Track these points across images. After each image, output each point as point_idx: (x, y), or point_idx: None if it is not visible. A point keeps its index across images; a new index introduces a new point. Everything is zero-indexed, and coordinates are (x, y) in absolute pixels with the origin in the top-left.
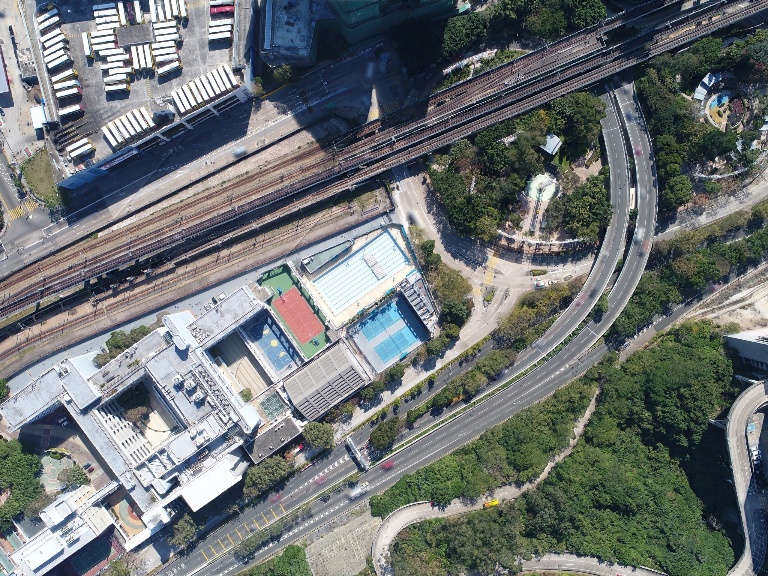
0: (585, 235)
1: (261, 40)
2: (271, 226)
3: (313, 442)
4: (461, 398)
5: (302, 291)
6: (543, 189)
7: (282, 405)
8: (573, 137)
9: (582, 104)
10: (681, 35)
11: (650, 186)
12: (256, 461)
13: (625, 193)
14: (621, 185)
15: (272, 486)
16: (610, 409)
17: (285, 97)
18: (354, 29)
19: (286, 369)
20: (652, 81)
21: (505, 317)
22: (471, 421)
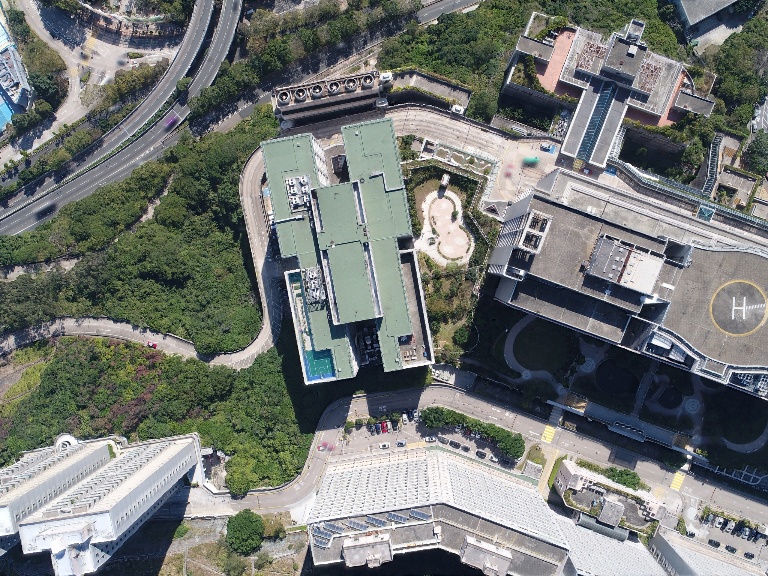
0: (166, 11)
1: None
2: None
3: None
4: (53, 178)
5: None
6: None
7: None
8: None
9: None
10: None
11: None
12: None
13: None
14: None
15: None
16: (177, 187)
17: None
18: None
19: None
20: None
21: (101, 99)
22: (58, 200)
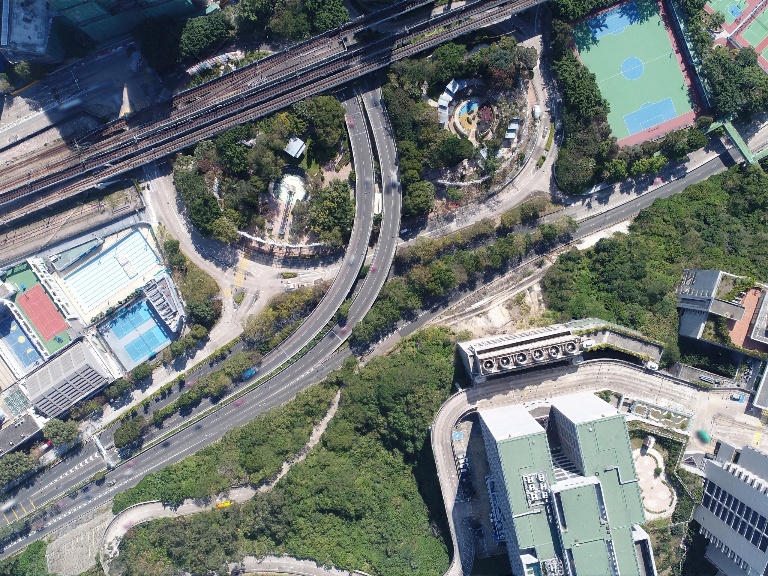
0: (326, 239)
1: None
2: (22, 222)
3: (52, 439)
4: (209, 399)
5: None
6: (293, 192)
7: (26, 401)
8: None
9: (322, 108)
10: (422, 41)
11: (395, 191)
12: None
13: (370, 198)
14: (367, 190)
15: (22, 481)
16: (345, 413)
17: (37, 94)
18: (87, 27)
19: (33, 365)
20: (393, 86)
21: None
22: (217, 422)
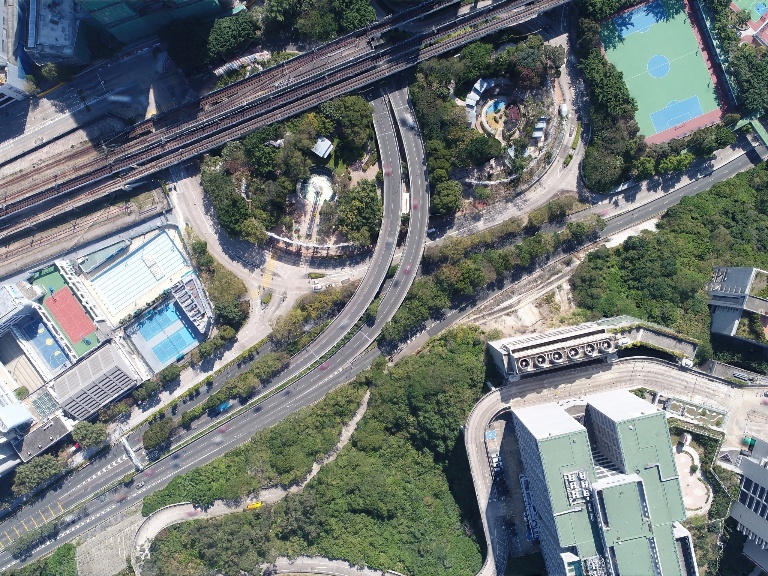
0: (354, 239)
1: (25, 38)
2: (48, 225)
3: (81, 441)
4: (237, 400)
5: (74, 290)
6: (320, 192)
7: (54, 404)
8: (348, 141)
9: (350, 108)
10: (450, 40)
11: (423, 191)
12: (25, 459)
13: (398, 198)
14: (394, 189)
15: (50, 484)
16: (375, 413)
17: (63, 95)
18: (115, 29)
19: (61, 368)
20: (421, 86)
21: None
22: (246, 423)
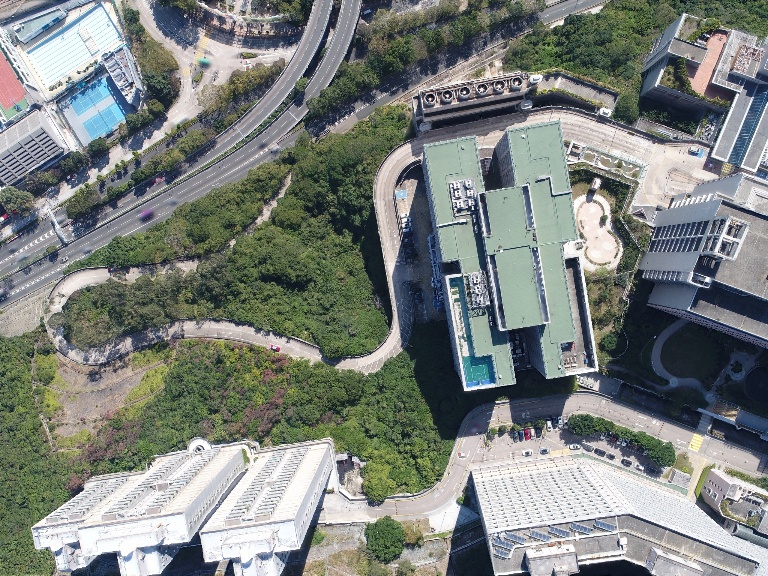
0: (285, 11)
1: None
2: None
3: (6, 205)
4: (164, 179)
5: (7, 55)
6: None
7: None
8: None
9: None
10: None
11: None
12: None
13: None
14: None
15: None
16: (295, 189)
17: None
18: None
19: None
20: None
21: None
22: (170, 201)
